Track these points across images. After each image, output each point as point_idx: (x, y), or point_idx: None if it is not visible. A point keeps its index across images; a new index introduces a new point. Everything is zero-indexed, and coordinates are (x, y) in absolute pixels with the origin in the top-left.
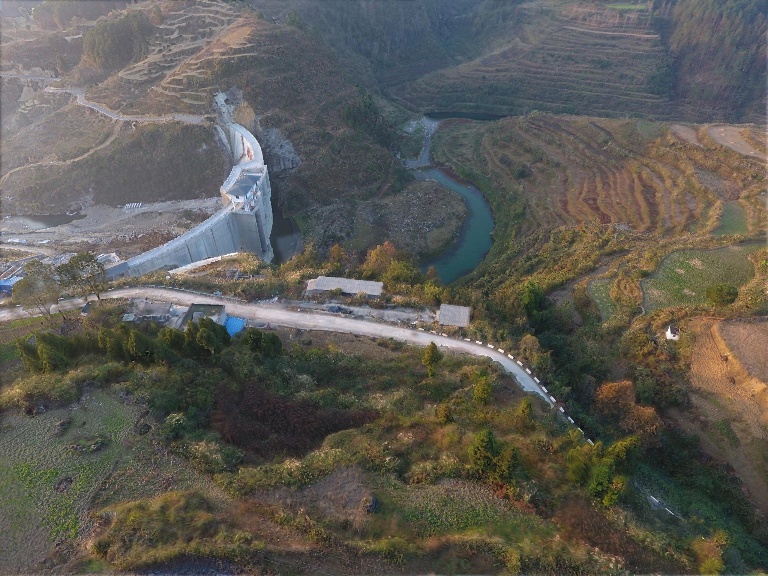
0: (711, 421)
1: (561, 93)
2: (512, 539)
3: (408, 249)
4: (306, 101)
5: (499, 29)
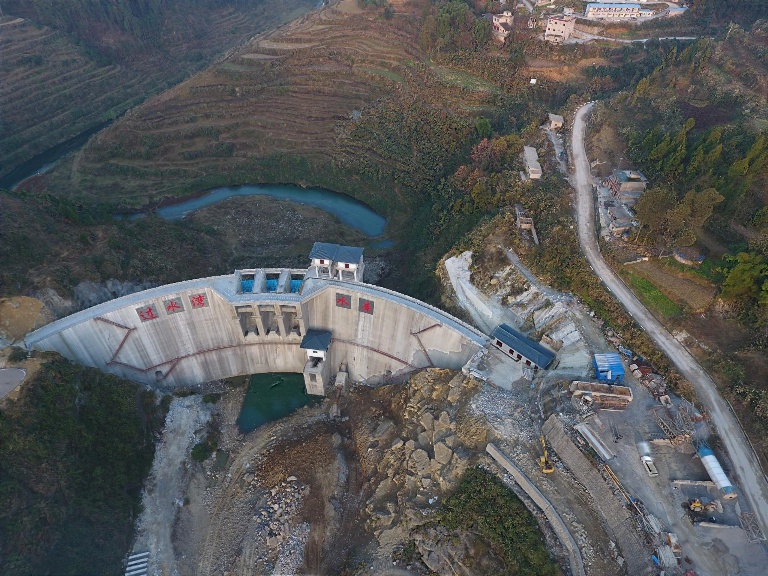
0: (579, 85)
1: (48, 103)
2: (721, 65)
3: (332, 227)
4: None
5: None
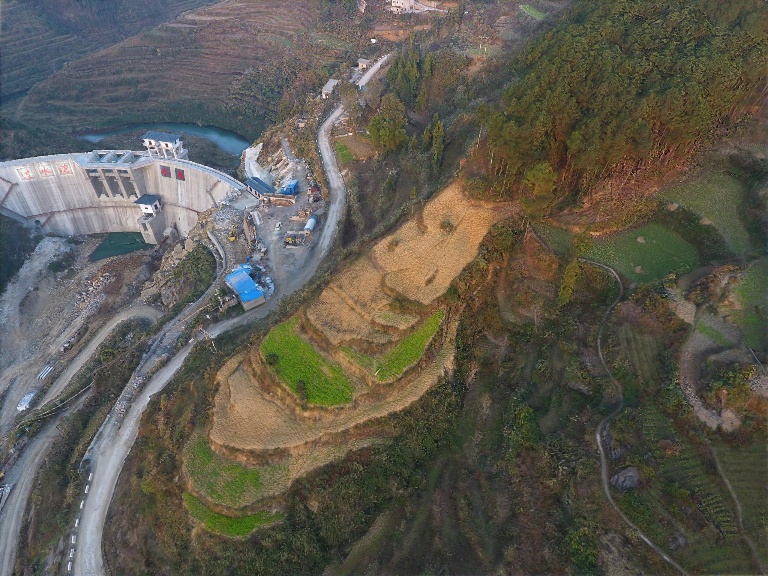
0: None
1: (8, 61)
2: None
3: (207, 149)
4: None
5: None
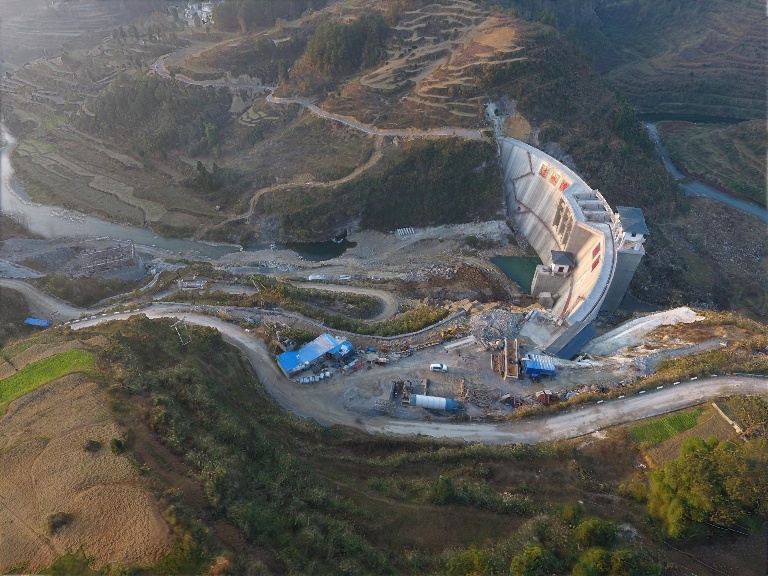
0: None
1: None
2: None
3: (756, 284)
4: (577, 110)
5: (676, 18)
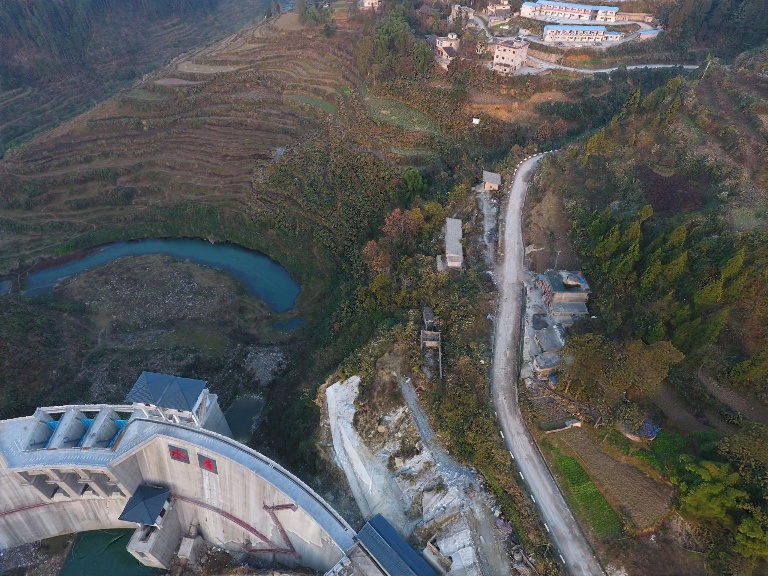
0: (530, 126)
1: None
2: (694, 116)
3: (230, 301)
4: None
5: None
